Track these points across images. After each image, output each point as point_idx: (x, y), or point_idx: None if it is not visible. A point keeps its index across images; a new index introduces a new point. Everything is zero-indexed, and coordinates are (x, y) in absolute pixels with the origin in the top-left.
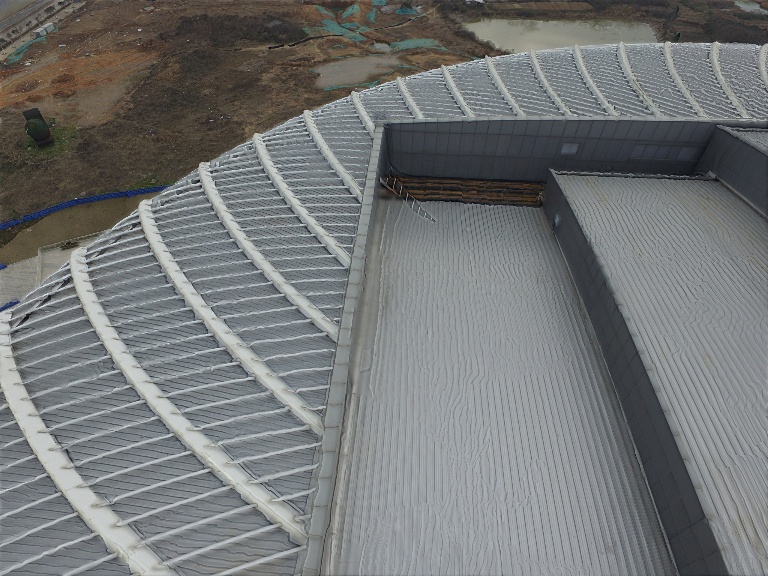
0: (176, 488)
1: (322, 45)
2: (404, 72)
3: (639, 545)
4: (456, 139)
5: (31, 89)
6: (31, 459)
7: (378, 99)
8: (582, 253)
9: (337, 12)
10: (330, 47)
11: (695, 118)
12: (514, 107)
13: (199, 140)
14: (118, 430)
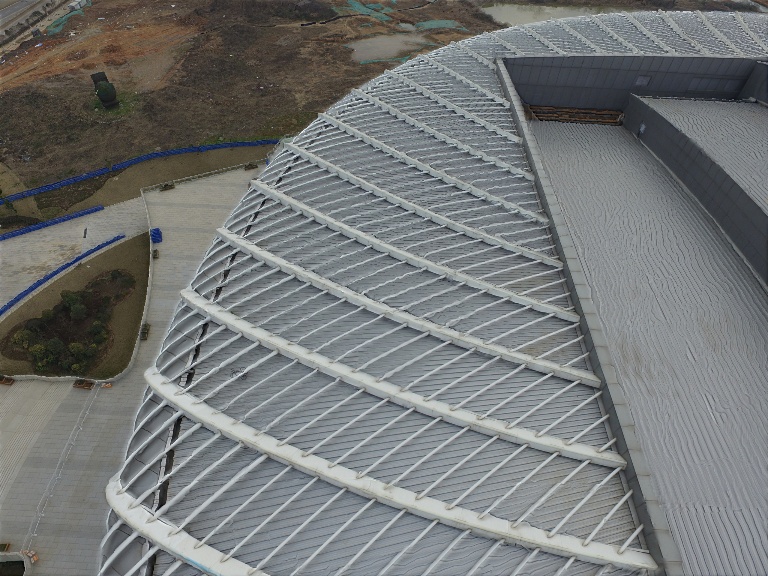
0: None
1: (351, 23)
2: (432, 49)
3: (747, 289)
4: (556, 72)
5: (82, 57)
6: (353, 241)
7: (481, 45)
8: (674, 141)
9: None
10: (359, 25)
11: (740, 56)
12: (598, 49)
13: (255, 104)
14: (405, 225)
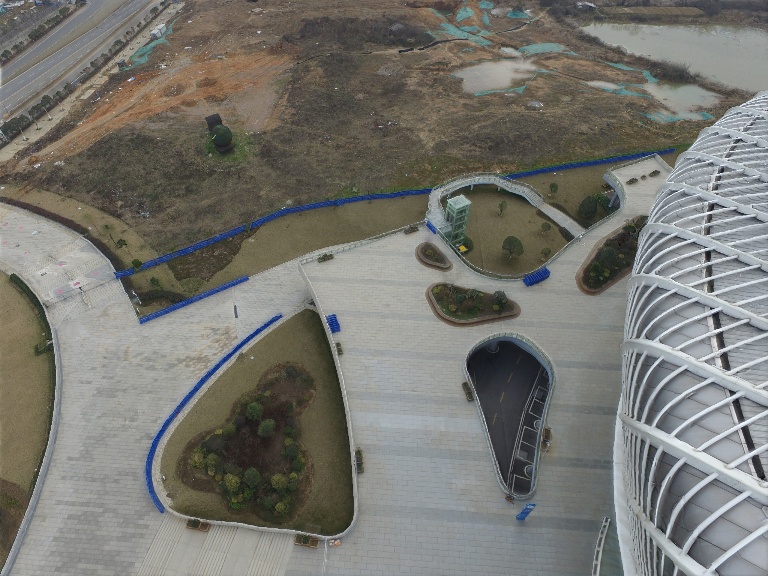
0: None
1: (452, 49)
2: (546, 77)
3: None
4: None
5: (179, 93)
6: None
7: None
8: None
9: (446, 15)
10: (460, 51)
11: None
12: None
13: (379, 147)
14: None
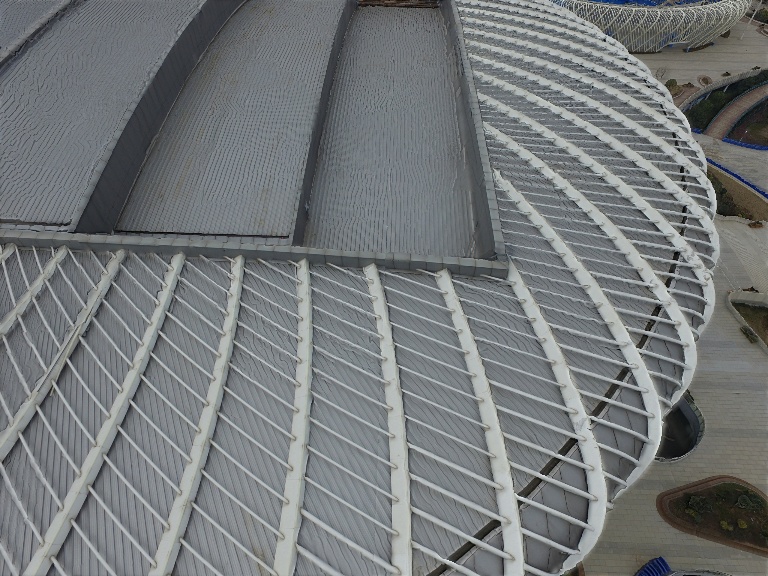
0: (520, 65)
1: None
2: None
3: None
4: None
5: None
6: None
7: (531, 379)
8: None
9: None
10: None
11: (89, 240)
12: None
13: None
14: None
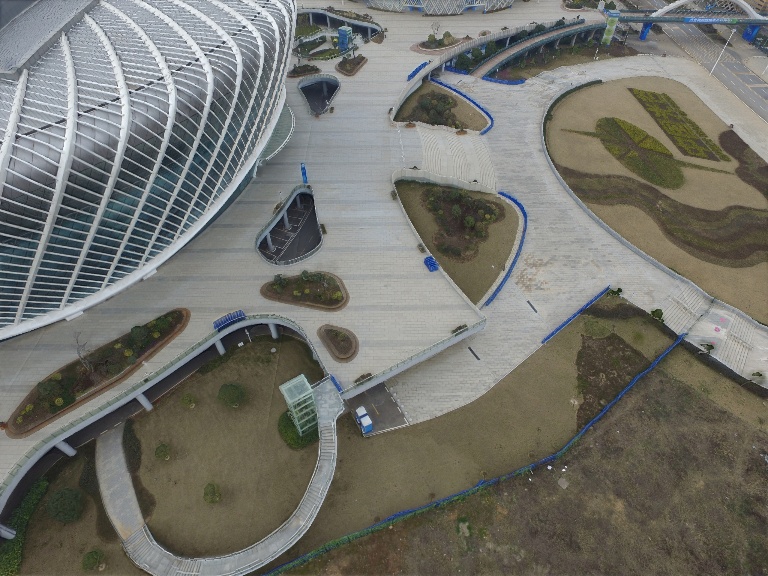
0: None
1: None
2: None
3: None
4: None
5: None
6: None
7: None
8: None
9: None
10: None
11: None
12: None
13: None
14: None
